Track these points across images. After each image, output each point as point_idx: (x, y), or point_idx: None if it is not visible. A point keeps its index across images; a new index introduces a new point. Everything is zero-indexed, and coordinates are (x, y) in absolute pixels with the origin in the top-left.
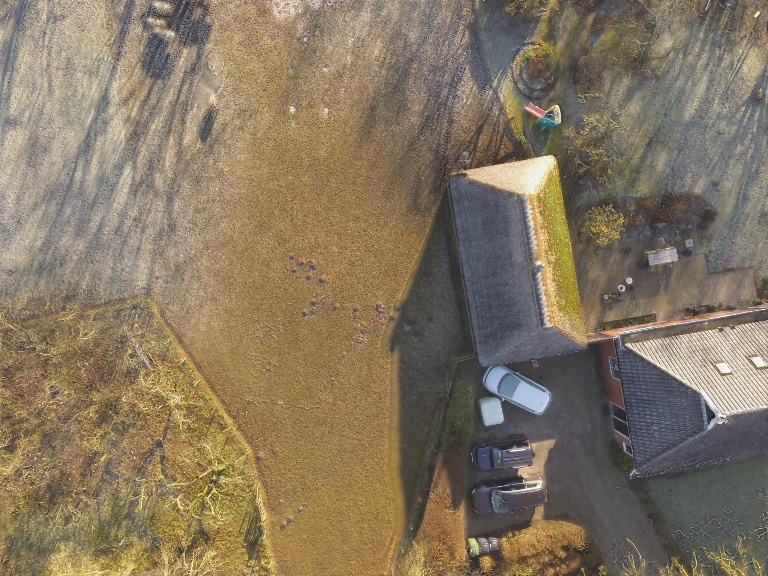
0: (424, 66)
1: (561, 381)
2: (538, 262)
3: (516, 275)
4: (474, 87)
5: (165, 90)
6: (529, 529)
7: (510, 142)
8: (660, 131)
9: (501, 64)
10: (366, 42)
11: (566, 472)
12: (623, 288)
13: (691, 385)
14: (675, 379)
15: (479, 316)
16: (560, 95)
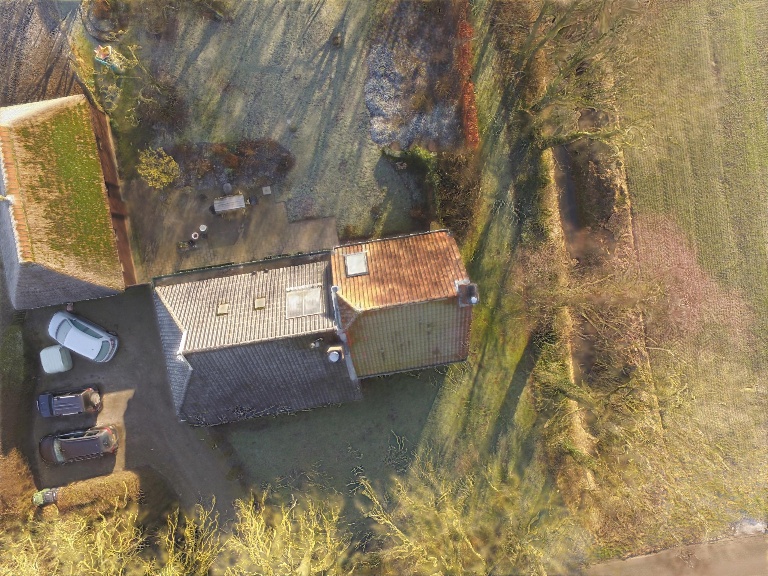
0: None
1: (138, 330)
2: (8, 195)
3: (5, 211)
4: (43, 29)
5: None
6: (94, 478)
7: (80, 85)
8: (236, 76)
9: (70, 6)
10: None
11: (147, 423)
12: (197, 235)
13: (180, 324)
14: (173, 319)
15: (4, 257)
16: (131, 38)
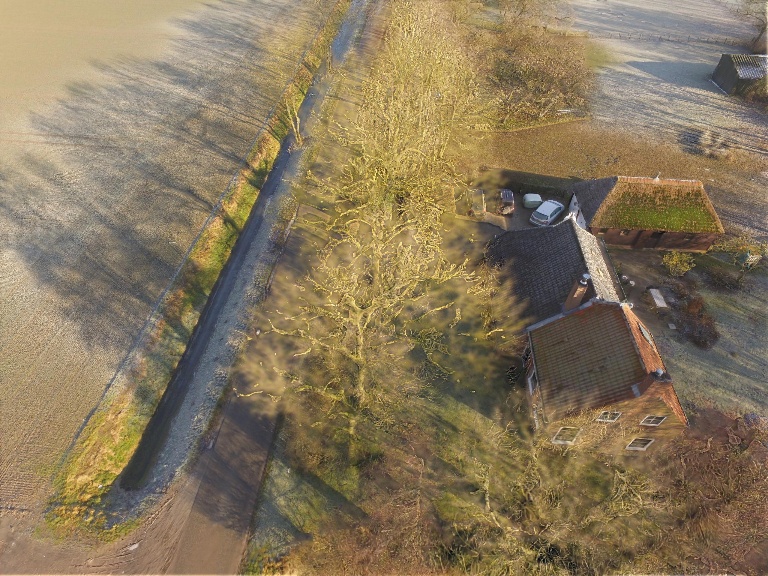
0: (759, 218)
1: None
2: None
3: None
4: (755, 236)
5: (702, 136)
6: None
7: None
8: (767, 327)
9: None
10: (763, 199)
11: (482, 232)
12: None
13: None
14: None
15: None
16: None
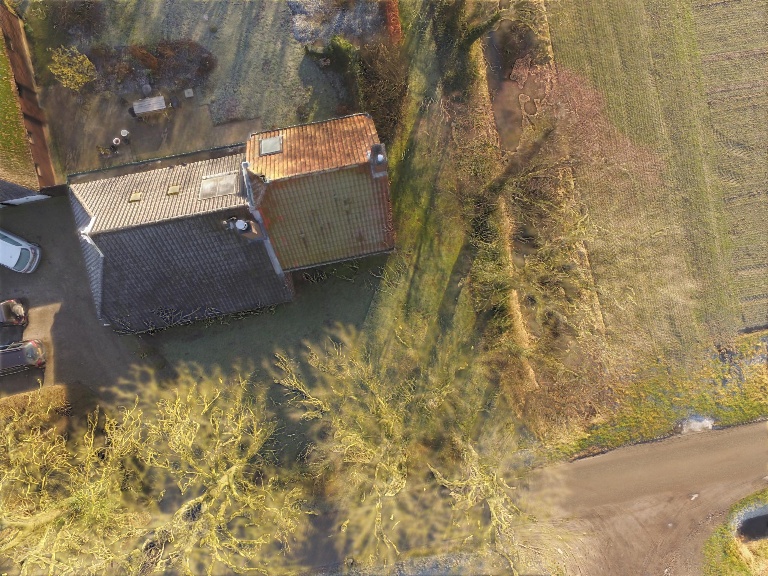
0: None
1: (62, 241)
2: None
3: None
4: None
5: None
6: (19, 394)
7: None
8: None
9: None
10: None
11: (75, 338)
12: (118, 141)
13: (89, 212)
14: None
15: None
16: None
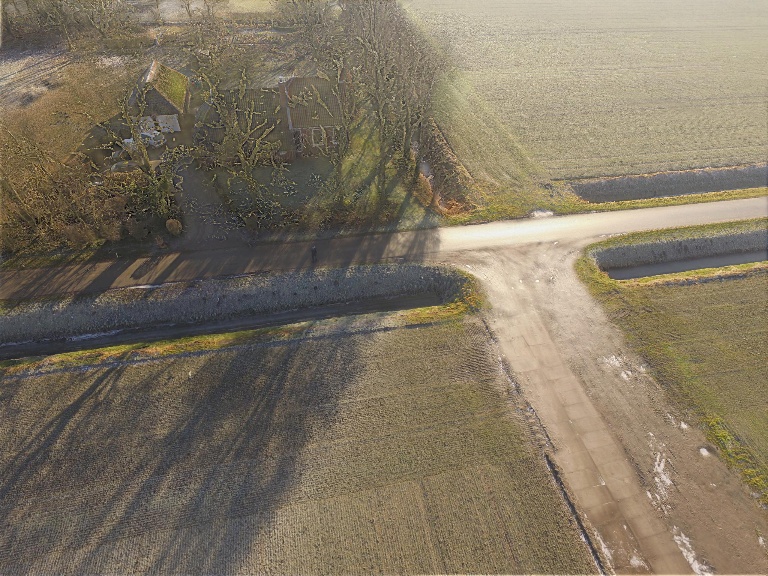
0: None
1: None
2: None
3: None
4: None
5: None
6: None
7: None
8: None
9: None
10: None
11: None
12: None
13: None
14: None
15: None
16: None
